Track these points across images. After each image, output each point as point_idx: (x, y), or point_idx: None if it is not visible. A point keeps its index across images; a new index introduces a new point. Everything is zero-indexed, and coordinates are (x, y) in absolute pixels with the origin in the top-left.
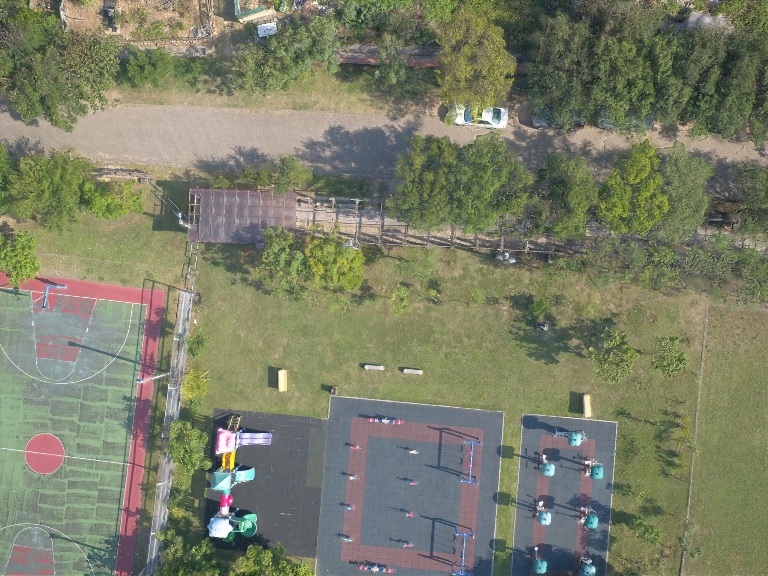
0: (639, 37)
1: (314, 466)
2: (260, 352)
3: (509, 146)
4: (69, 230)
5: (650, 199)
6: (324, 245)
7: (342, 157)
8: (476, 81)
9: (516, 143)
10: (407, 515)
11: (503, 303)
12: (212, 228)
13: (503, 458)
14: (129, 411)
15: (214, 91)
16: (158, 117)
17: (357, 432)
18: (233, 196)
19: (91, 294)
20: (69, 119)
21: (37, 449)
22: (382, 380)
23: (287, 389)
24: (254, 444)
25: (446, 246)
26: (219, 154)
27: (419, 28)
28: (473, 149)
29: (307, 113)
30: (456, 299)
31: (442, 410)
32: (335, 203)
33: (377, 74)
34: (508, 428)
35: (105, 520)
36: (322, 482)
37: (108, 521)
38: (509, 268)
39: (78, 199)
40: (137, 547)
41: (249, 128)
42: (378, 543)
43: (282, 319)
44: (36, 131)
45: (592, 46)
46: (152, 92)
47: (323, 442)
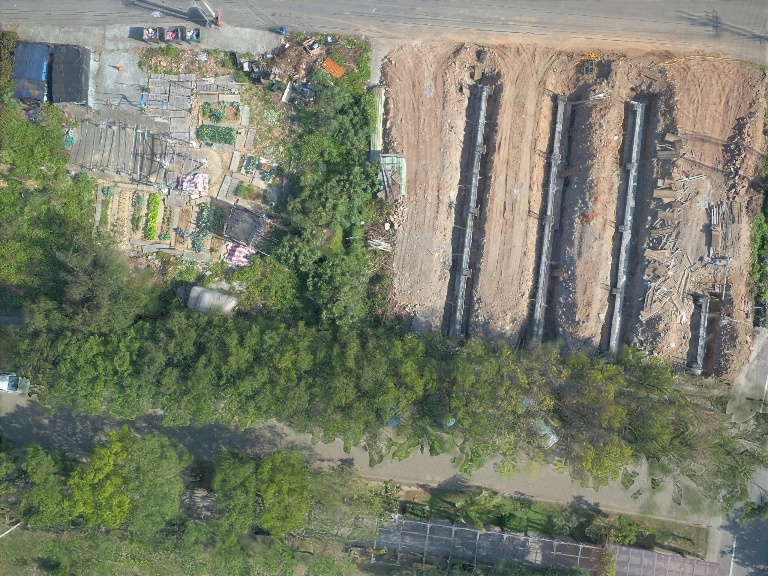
0: (107, 332)
1: None
2: None
3: (35, 409)
4: None
5: (110, 498)
6: None
7: None
8: None
9: (42, 406)
10: None
11: (27, 567)
12: None
13: None
14: None
15: None
16: None
17: None
18: None
19: None
20: None
21: None
22: None
23: None
24: None
25: None
26: None
27: None
28: None
29: None
30: None
31: None
32: None
33: None
34: None
35: None
36: None
37: None
38: (36, 530)
39: None
40: None
41: None
42: None
43: None
44: None
45: (57, 343)
46: None
47: None
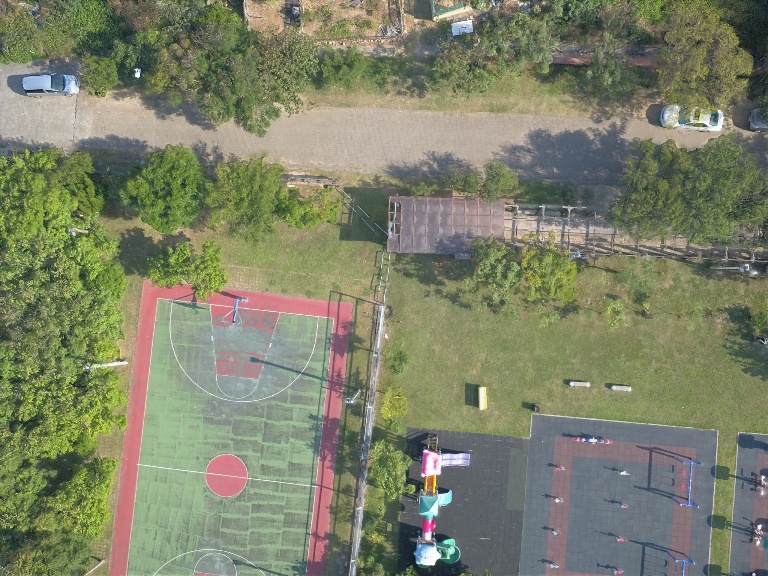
0: None
1: (515, 488)
2: (456, 368)
3: None
4: (263, 241)
5: None
6: (542, 256)
7: (543, 162)
8: (707, 81)
9: None
10: (618, 540)
11: (719, 316)
12: (414, 238)
13: (717, 479)
14: (316, 430)
15: (405, 93)
16: (345, 120)
17: (561, 452)
18: (436, 204)
19: (274, 307)
20: (263, 123)
21: (218, 471)
22: (588, 397)
23: (486, 407)
24: (451, 465)
25: (656, 256)
26: (411, 159)
27: (626, 25)
28: (709, 154)
29: (505, 116)
30: (666, 311)
31: (652, 429)
32: (541, 211)
33: (590, 74)
34: (723, 447)
35: (292, 545)
36: (524, 505)
37: (295, 546)
38: (723, 278)
39: (274, 208)
40: (326, 574)
41: (443, 132)
42: (584, 569)
43: (480, 333)
44: (214, 136)
45: None
46: (338, 94)
47: (525, 463)
